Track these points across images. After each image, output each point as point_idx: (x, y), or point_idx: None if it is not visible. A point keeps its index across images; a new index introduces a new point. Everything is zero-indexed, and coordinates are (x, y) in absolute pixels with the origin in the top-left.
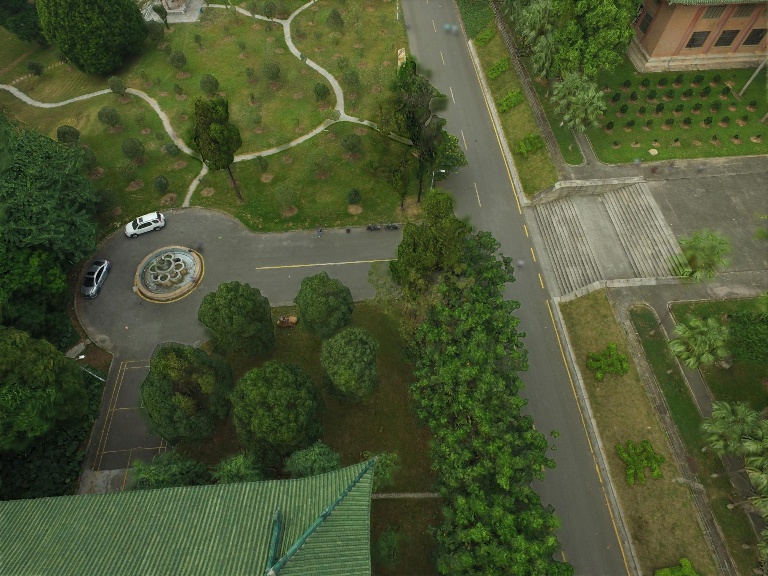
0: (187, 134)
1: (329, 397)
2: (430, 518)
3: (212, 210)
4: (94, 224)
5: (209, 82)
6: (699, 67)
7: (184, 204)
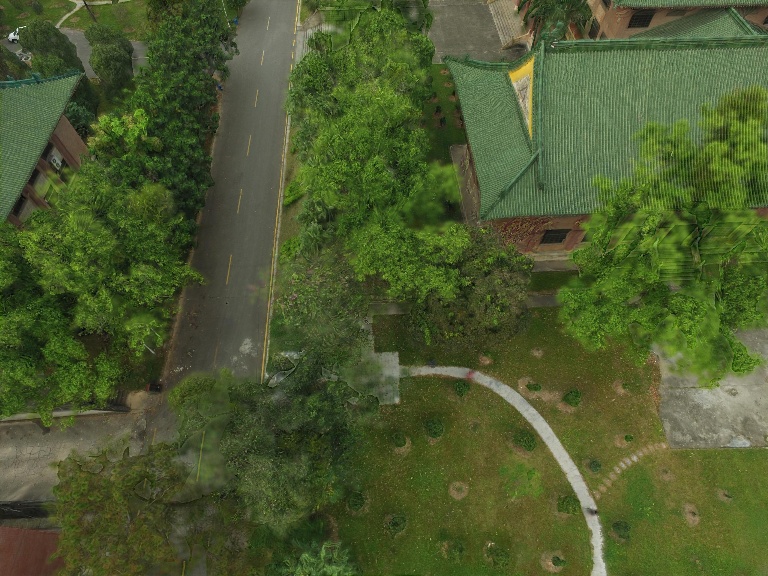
0: None
1: None
2: None
3: (75, 30)
4: None
5: None
6: None
7: (56, 26)
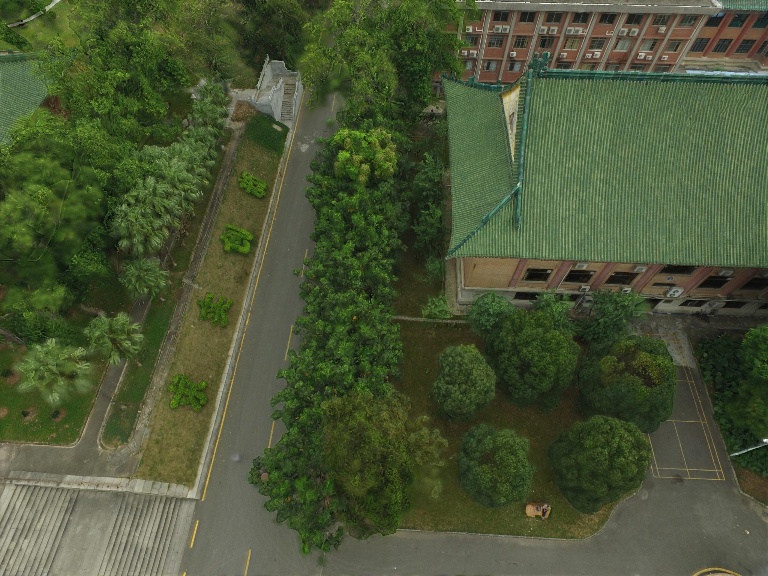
0: None
1: None
2: (394, 302)
3: None
4: None
5: None
6: None
7: None
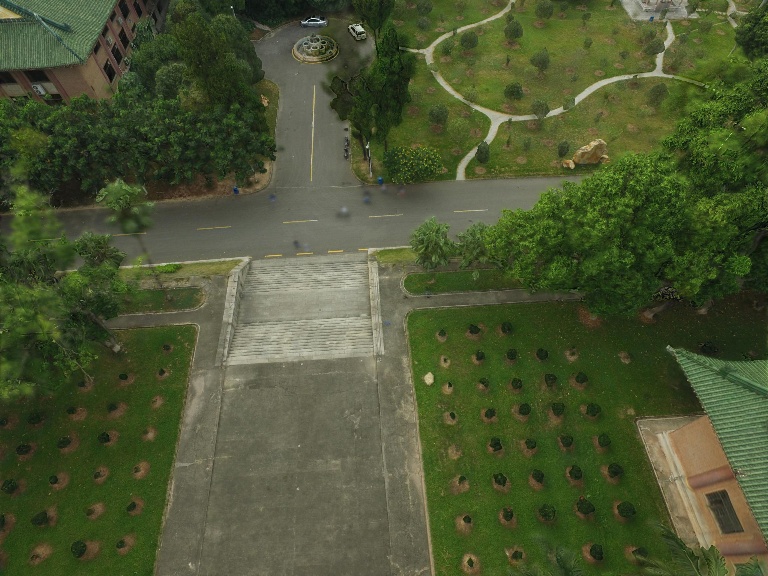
0: (459, 37)
1: None
2: None
3: None
4: (340, 0)
5: (510, 26)
6: (691, 547)
7: None
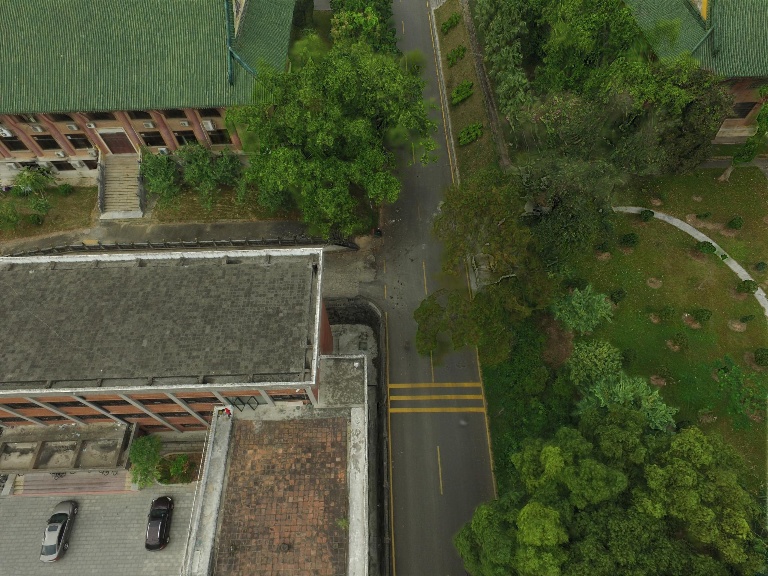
0: None
1: (291, 43)
2: None
3: None
4: None
5: None
6: None
7: None
